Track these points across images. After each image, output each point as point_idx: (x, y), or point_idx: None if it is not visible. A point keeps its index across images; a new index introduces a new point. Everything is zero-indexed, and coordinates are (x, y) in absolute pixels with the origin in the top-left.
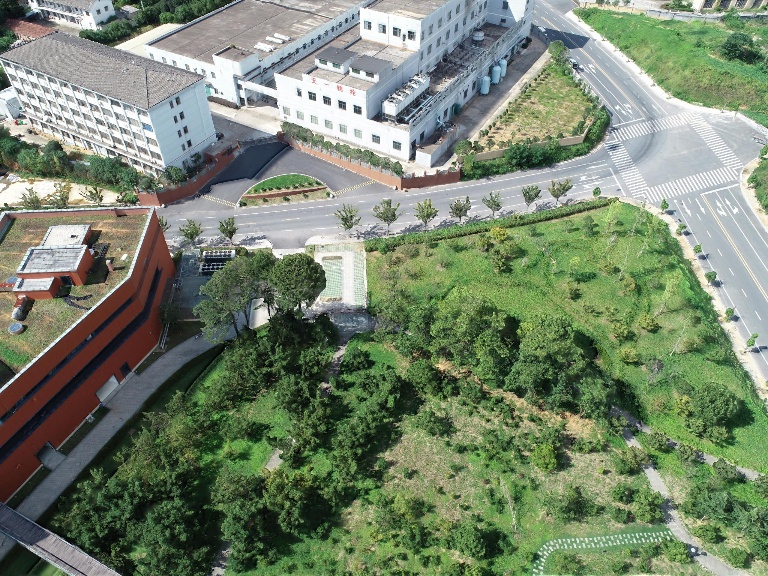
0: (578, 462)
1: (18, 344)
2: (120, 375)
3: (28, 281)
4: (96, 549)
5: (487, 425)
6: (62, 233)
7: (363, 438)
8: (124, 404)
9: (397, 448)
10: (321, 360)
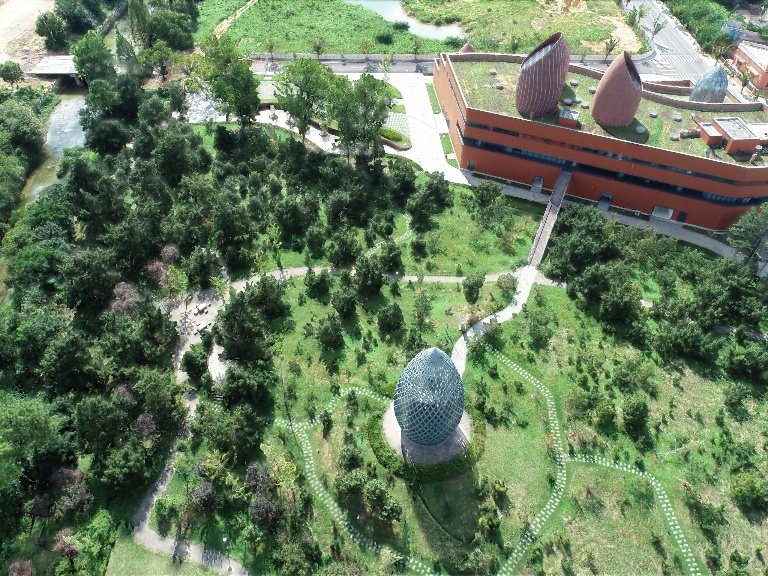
0: (759, 529)
1: (663, 141)
2: (676, 216)
3: (711, 127)
4: (558, 228)
5: (759, 448)
6: (765, 129)
7: (692, 339)
8: (656, 226)
9: (698, 377)
10: (754, 311)
